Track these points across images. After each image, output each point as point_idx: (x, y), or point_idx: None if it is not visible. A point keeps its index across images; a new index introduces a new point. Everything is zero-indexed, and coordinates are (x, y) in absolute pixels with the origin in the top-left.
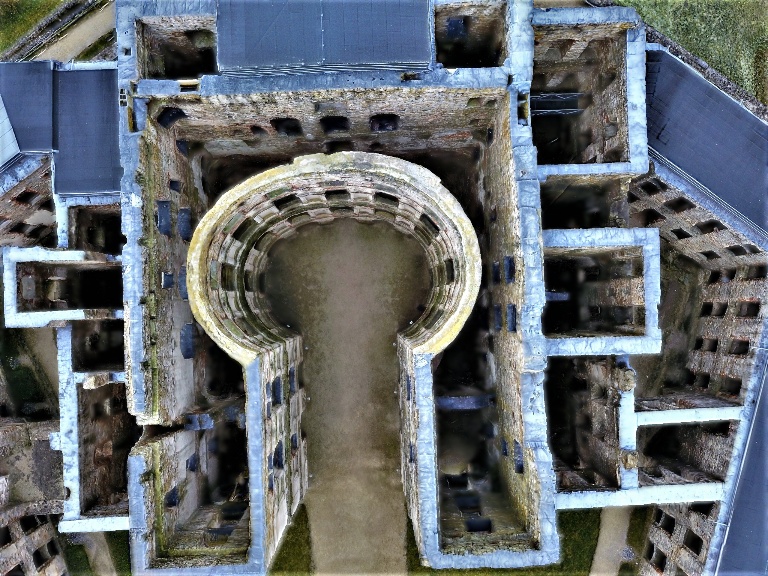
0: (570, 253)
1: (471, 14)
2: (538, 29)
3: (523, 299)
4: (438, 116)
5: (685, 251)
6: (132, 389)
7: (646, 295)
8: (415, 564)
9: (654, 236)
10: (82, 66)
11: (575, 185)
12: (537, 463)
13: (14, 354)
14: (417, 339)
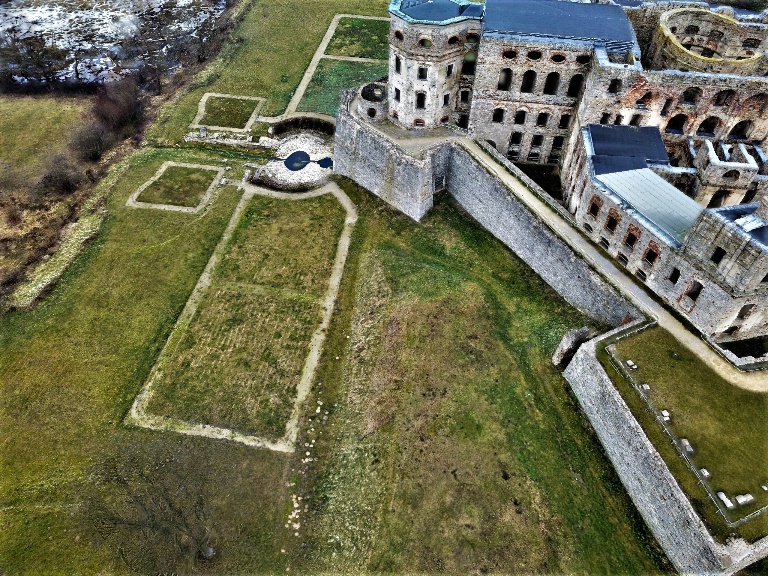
0: None
1: None
2: None
3: (707, 7)
4: None
5: None
6: None
7: None
8: None
9: None
10: (588, 153)
11: None
12: None
13: None
14: (724, 46)
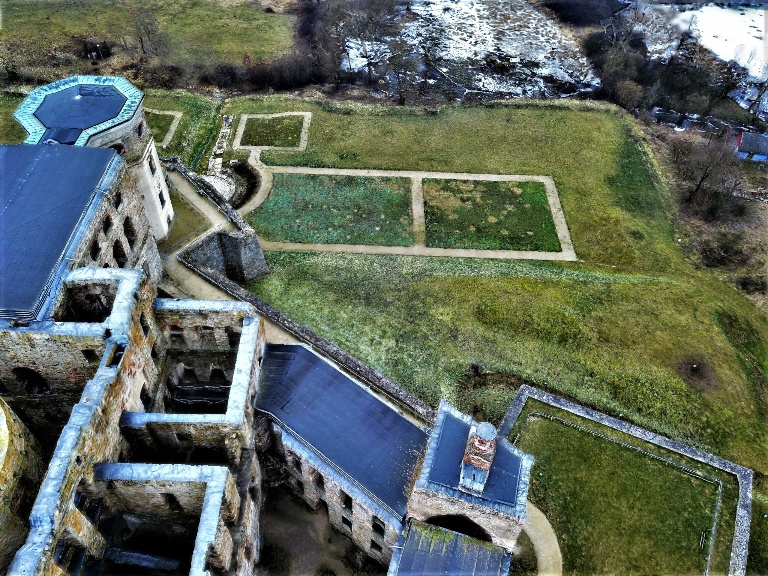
0: (182, 513)
1: (101, 293)
2: (171, 314)
3: None
4: (75, 375)
5: (366, 550)
6: None
7: (198, 533)
8: None
9: (221, 474)
10: None
11: (201, 447)
12: None
13: None
14: None
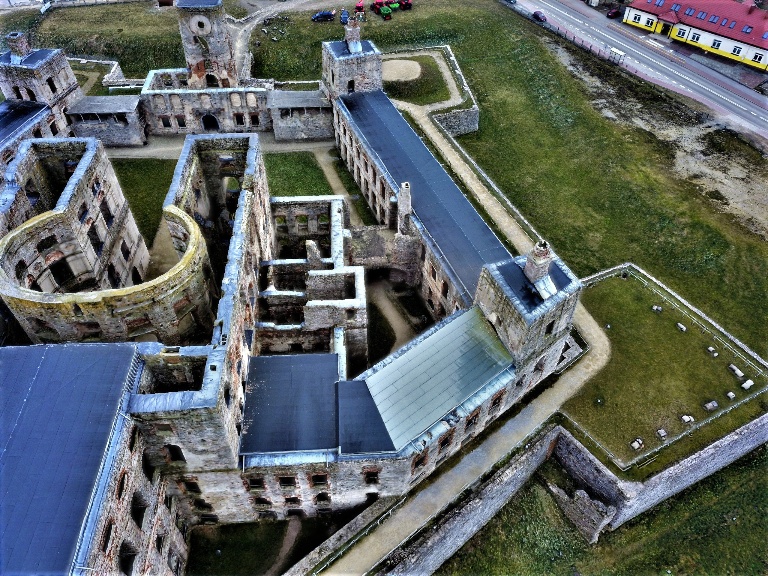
0: None
1: None
2: None
3: None
4: None
5: None
6: (245, 198)
7: None
8: (155, 220)
9: None
10: (318, 459)
11: None
12: (14, 172)
13: (424, 324)
14: (70, 243)
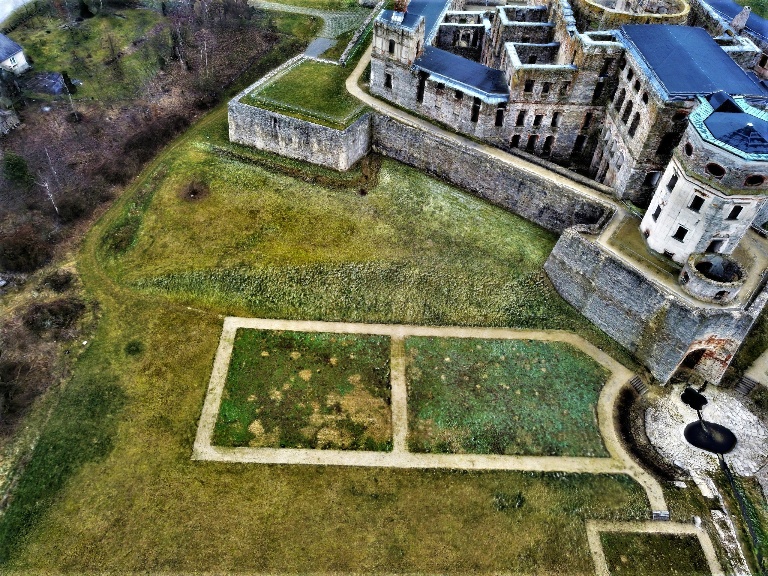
0: None
1: None
2: None
3: None
4: None
5: None
6: None
7: None
8: None
9: (505, 22)
10: (767, 108)
11: None
12: None
13: None
14: None
